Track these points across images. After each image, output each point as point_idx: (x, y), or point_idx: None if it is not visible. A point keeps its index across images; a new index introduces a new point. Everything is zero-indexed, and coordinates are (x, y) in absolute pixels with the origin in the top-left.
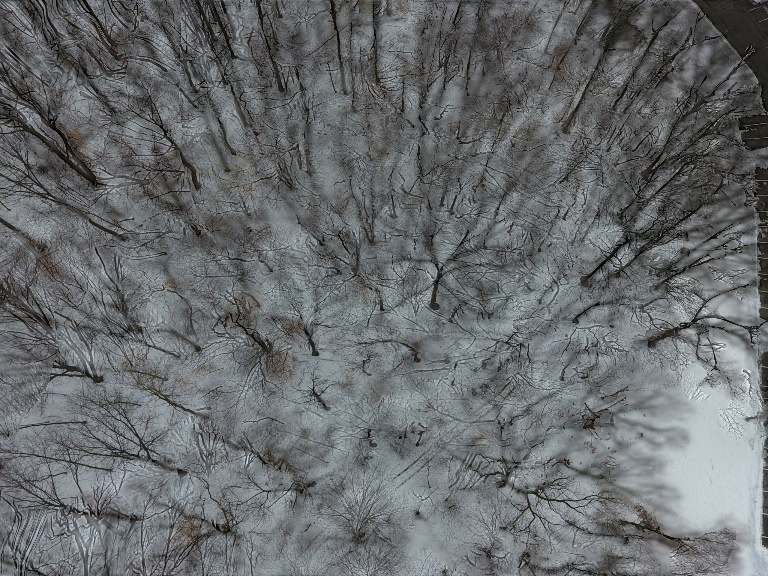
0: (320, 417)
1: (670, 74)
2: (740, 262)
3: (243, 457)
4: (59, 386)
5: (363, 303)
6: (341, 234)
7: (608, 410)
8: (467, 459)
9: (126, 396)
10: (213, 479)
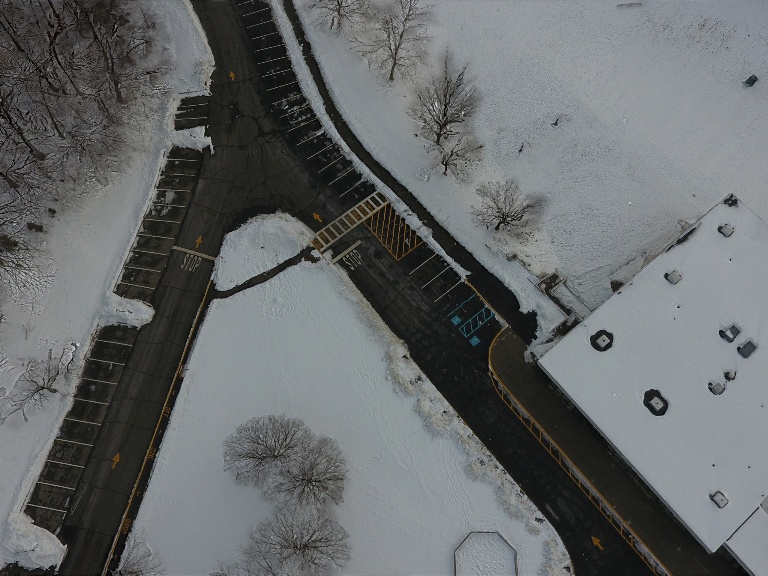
0: None
1: (136, 56)
2: (115, 239)
3: None
4: None
5: None
6: None
7: None
8: None
9: None
10: None
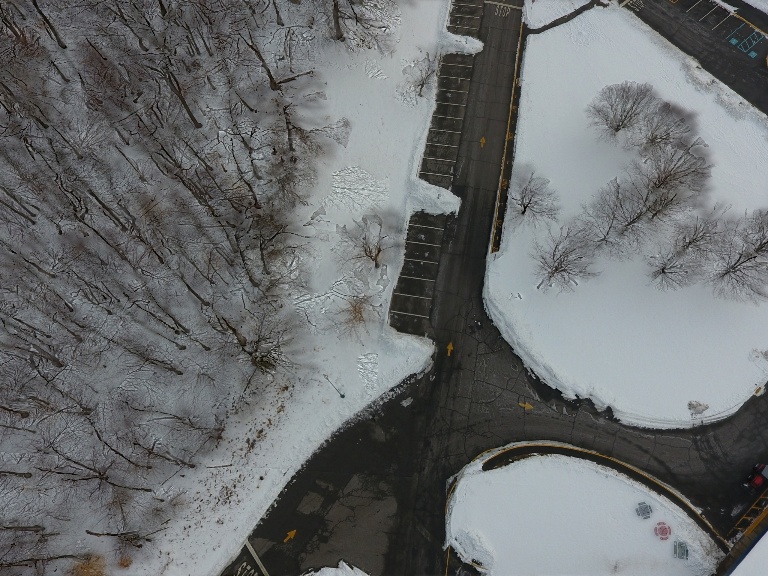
0: (59, 84)
1: None
2: None
3: None
4: None
5: (109, 15)
6: None
7: (296, 80)
8: None
9: None
10: None
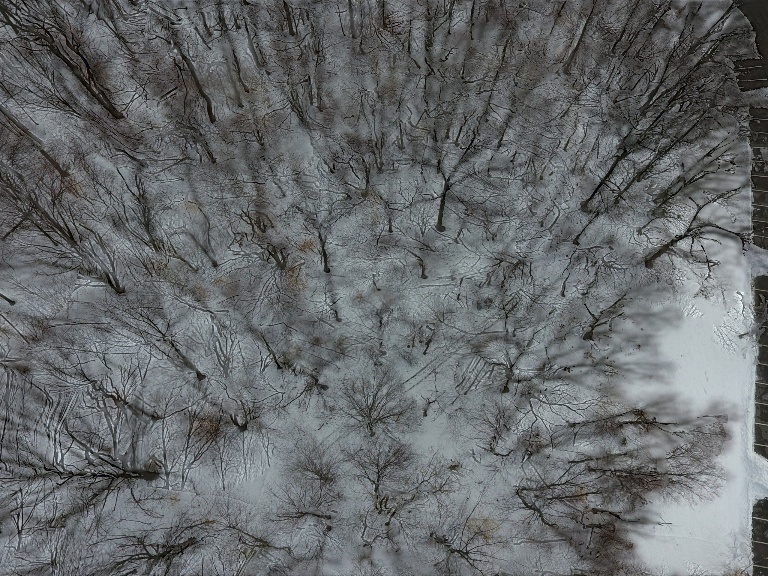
0: (332, 327)
1: (667, 21)
2: None
3: (259, 362)
4: (83, 295)
5: (372, 225)
6: (351, 161)
7: (607, 324)
8: (472, 362)
9: (148, 302)
10: (230, 381)
